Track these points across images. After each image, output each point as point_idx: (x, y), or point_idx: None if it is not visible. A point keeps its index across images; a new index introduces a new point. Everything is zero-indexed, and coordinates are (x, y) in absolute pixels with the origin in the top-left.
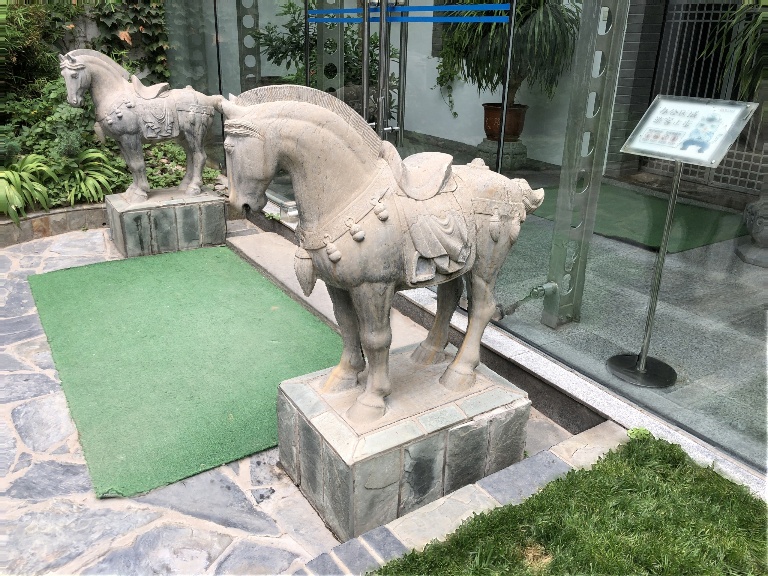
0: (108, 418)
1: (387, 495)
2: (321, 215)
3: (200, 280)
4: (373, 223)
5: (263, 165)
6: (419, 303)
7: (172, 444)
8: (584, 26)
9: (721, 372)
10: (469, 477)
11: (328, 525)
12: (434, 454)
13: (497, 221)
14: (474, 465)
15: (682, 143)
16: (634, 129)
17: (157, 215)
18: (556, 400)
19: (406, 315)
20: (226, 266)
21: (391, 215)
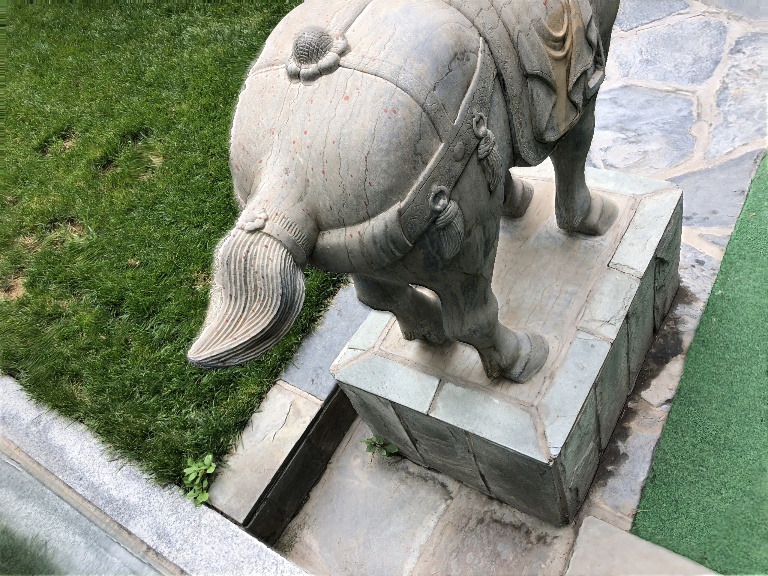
0: None
1: None
2: None
3: None
4: None
5: None
6: None
7: None
8: None
9: None
10: None
11: None
12: None
13: None
14: None
15: None
16: None
17: None
18: None
19: None
20: None
21: None
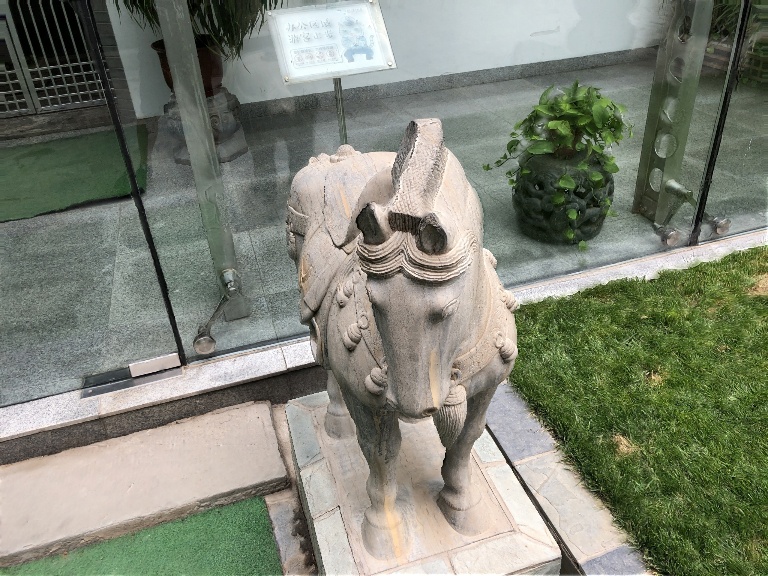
0: None
1: None
2: (481, 314)
3: None
4: None
5: None
6: (86, 417)
7: None
8: None
9: None
10: None
11: None
12: None
13: None
14: None
15: (343, 55)
16: (276, 57)
17: None
18: None
19: (62, 450)
20: None
21: None
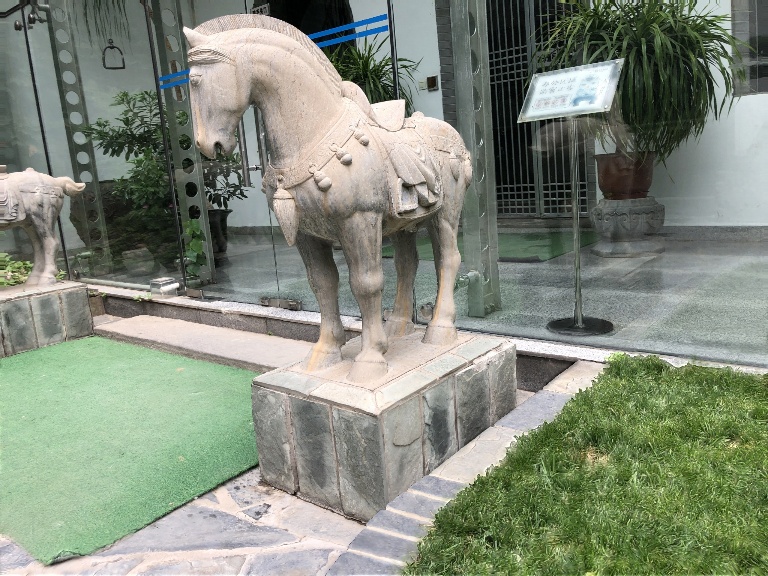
0: (21, 495)
1: (413, 454)
2: (301, 145)
3: (79, 364)
4: (356, 147)
5: (236, 93)
6: None
7: (121, 496)
8: (457, 28)
9: (643, 316)
10: (478, 432)
11: (350, 515)
12: (446, 404)
13: (455, 158)
14: (481, 417)
15: (572, 102)
16: None
17: (8, 309)
18: (517, 366)
19: None
20: (104, 349)
21: (370, 142)
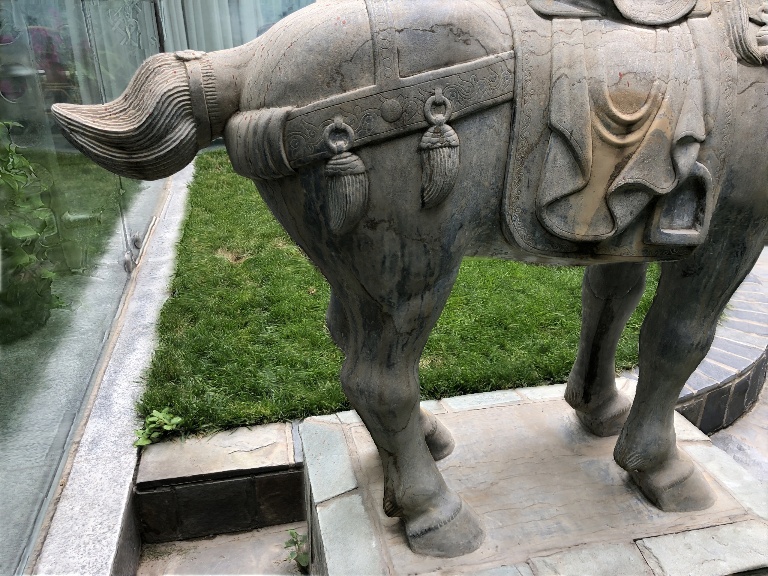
0: None
1: None
2: None
3: None
4: None
5: None
6: None
7: None
8: None
9: None
10: None
11: None
12: None
13: None
14: None
15: None
16: None
17: None
18: None
19: None
20: None
21: None
